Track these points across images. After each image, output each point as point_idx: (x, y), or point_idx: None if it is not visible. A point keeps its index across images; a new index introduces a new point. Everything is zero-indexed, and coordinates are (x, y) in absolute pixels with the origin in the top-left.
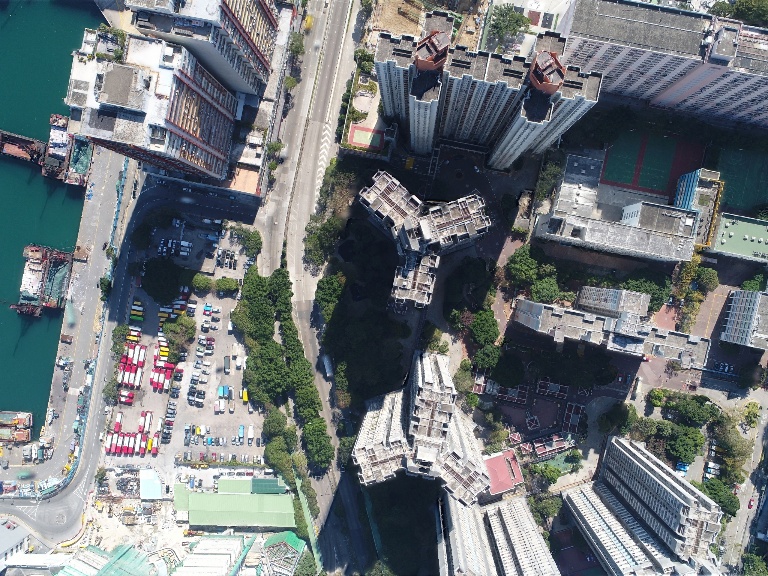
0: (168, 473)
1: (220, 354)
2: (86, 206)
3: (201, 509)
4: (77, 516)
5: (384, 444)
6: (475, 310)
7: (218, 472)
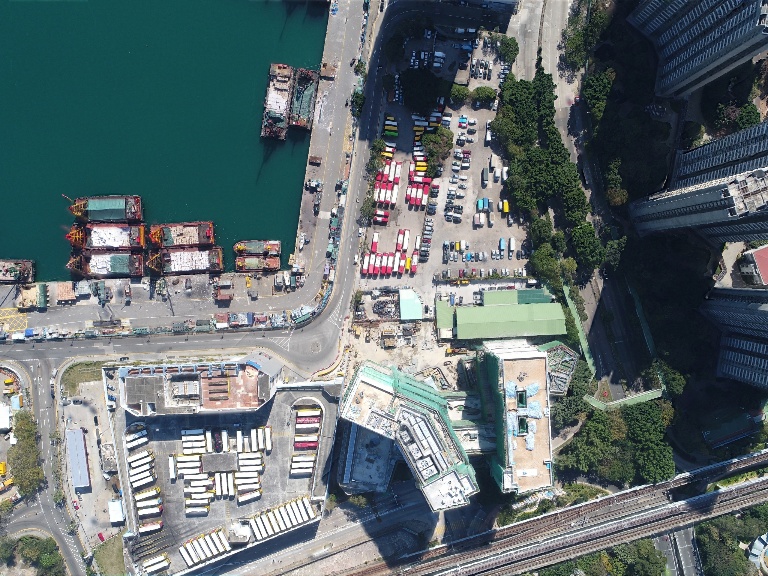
0: (426, 293)
1: (476, 167)
2: (331, 22)
3: (470, 322)
4: (333, 343)
5: (755, 175)
6: (738, 105)
7: (478, 288)
